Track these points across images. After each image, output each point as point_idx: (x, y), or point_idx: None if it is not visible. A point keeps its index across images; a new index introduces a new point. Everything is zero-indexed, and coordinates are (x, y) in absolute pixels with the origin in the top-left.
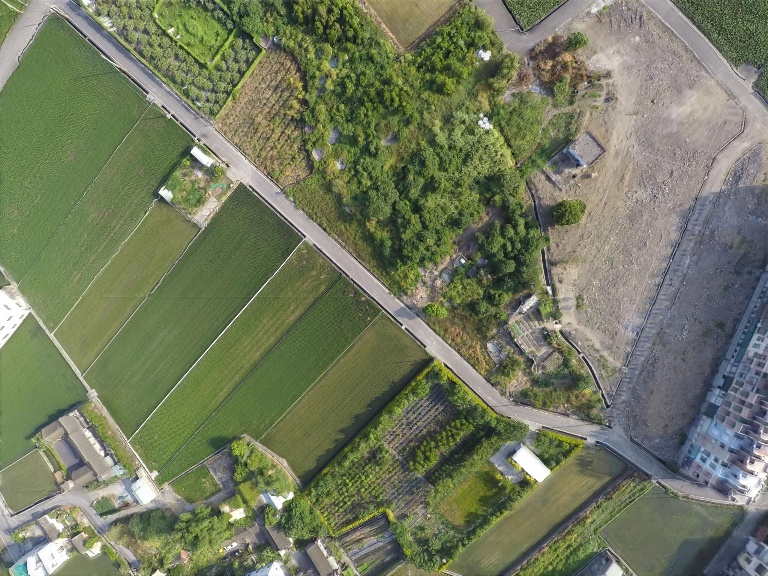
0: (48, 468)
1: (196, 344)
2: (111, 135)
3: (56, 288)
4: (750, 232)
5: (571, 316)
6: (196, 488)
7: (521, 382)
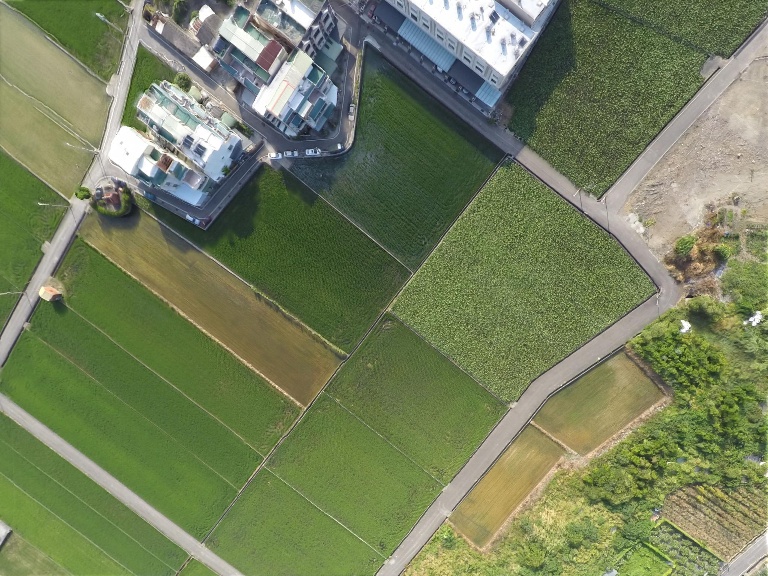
0: None
1: None
2: None
3: None
4: None
5: None
6: None
7: None
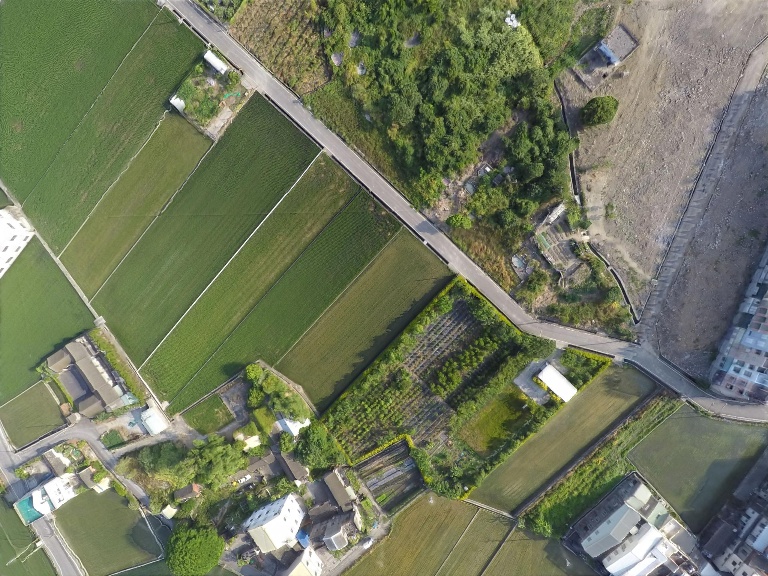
0: (54, 401)
1: (208, 266)
2: (120, 42)
3: (62, 208)
4: None
5: (600, 226)
6: (208, 419)
7: (547, 298)
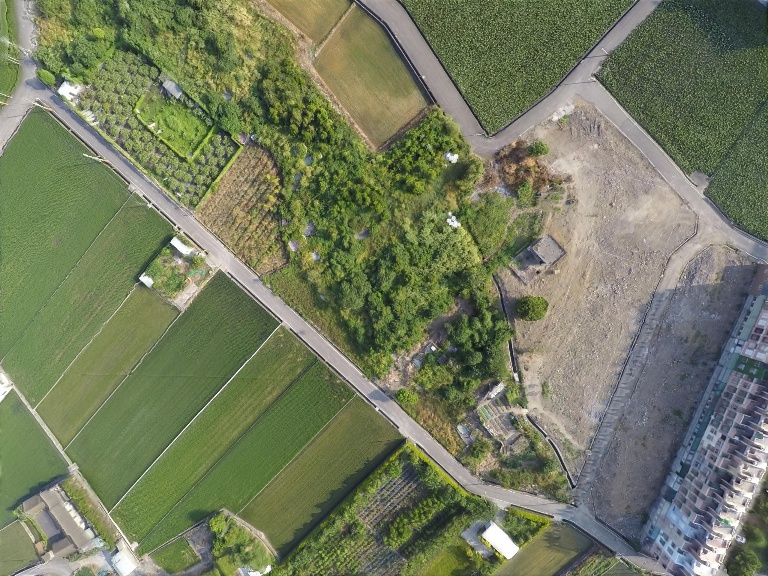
0: (29, 538)
1: (176, 420)
2: (93, 222)
3: (38, 365)
4: (704, 327)
5: (537, 401)
6: (176, 559)
7: (490, 463)
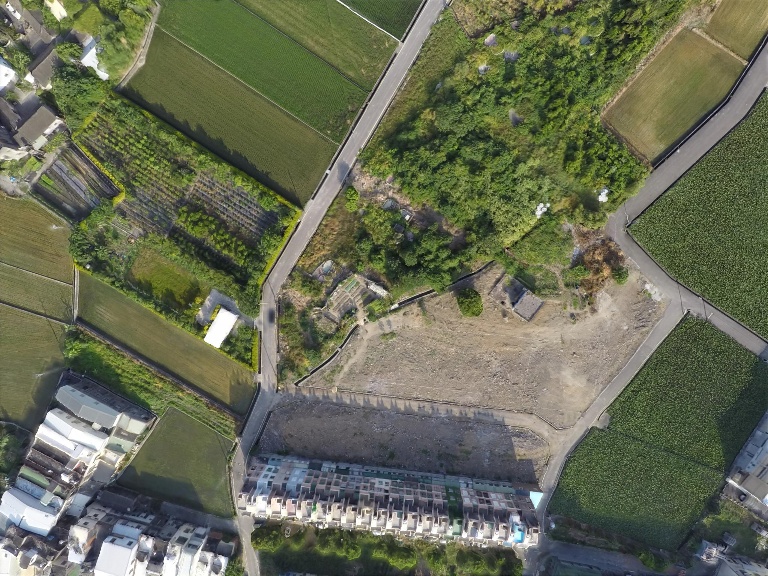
0: None
1: None
2: None
3: None
4: (475, 456)
5: (374, 331)
6: None
7: (300, 301)
